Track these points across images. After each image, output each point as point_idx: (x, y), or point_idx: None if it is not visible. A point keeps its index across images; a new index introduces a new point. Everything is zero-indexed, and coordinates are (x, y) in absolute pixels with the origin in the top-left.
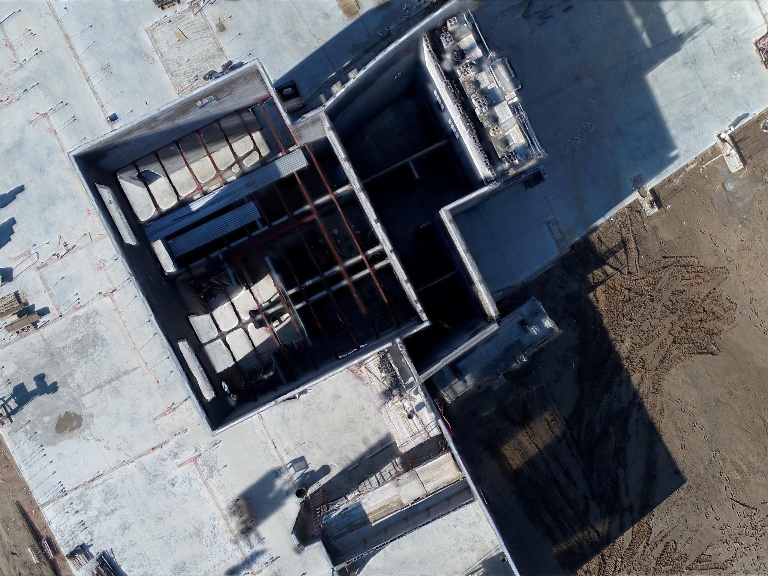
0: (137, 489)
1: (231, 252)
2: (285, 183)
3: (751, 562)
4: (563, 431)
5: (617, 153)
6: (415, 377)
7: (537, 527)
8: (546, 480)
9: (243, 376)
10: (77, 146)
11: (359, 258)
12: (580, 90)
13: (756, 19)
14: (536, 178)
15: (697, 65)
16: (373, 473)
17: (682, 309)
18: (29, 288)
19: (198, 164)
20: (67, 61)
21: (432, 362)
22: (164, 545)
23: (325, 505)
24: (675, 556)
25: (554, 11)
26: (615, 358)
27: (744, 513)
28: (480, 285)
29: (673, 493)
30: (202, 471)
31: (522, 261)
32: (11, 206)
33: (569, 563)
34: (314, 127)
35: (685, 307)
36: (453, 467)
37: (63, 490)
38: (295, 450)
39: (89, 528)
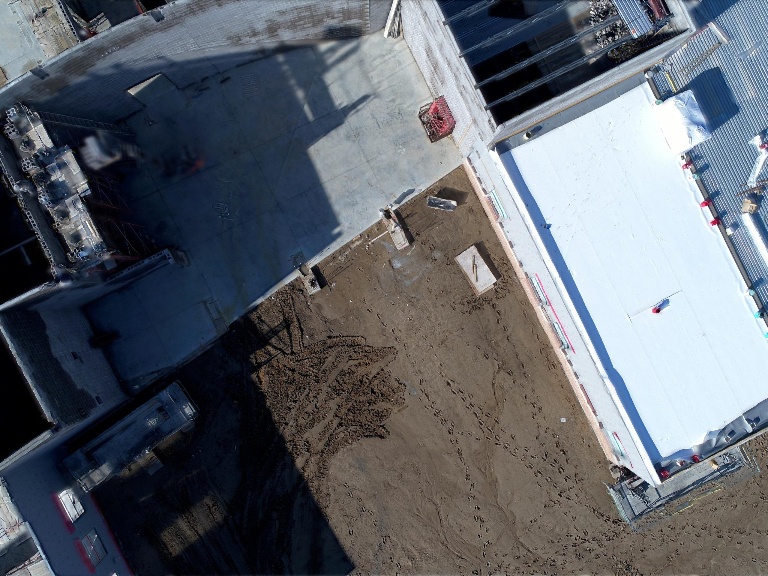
0: None
1: None
2: None
3: None
4: (225, 516)
5: (277, 230)
6: None
7: None
8: (207, 567)
9: None
10: None
11: None
12: (239, 164)
13: (422, 91)
14: None
15: (360, 139)
16: (22, 561)
17: (349, 390)
18: None
19: None
20: None
21: None
22: None
23: None
24: None
25: (211, 82)
26: (279, 441)
27: None
28: (33, 390)
29: None
30: None
31: (178, 341)
32: None
33: None
34: None
35: (353, 388)
36: None
37: None
38: None
39: None
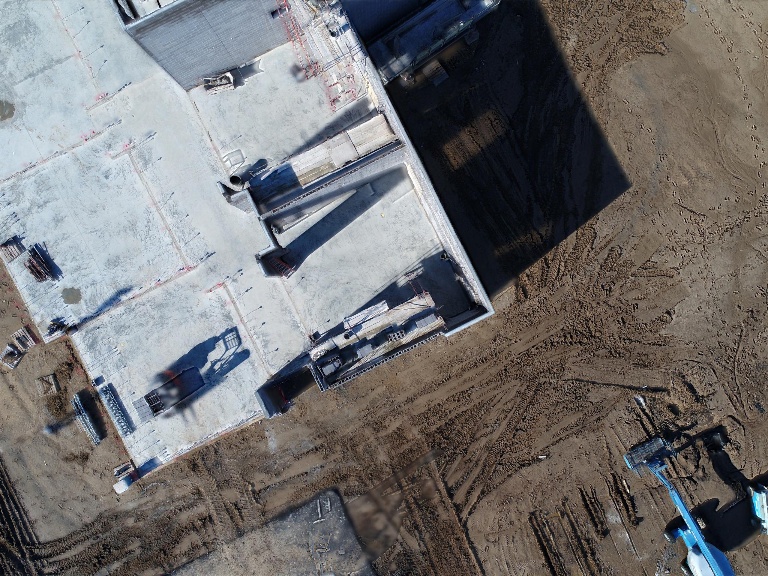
0: (70, 181)
1: None
2: None
3: (698, 270)
4: (506, 130)
5: None
6: None
7: (479, 229)
8: (488, 181)
9: None
10: None
11: None
12: None
13: None
14: None
15: None
16: None
17: (630, 6)
18: None
19: None
20: None
21: None
22: (97, 239)
23: None
24: (620, 262)
25: None
26: (561, 56)
27: (692, 219)
28: None
29: (619, 197)
30: (136, 163)
31: None
32: None
33: (511, 267)
34: None
35: (633, 5)
36: (386, 129)
37: None
38: (231, 143)
39: (21, 220)
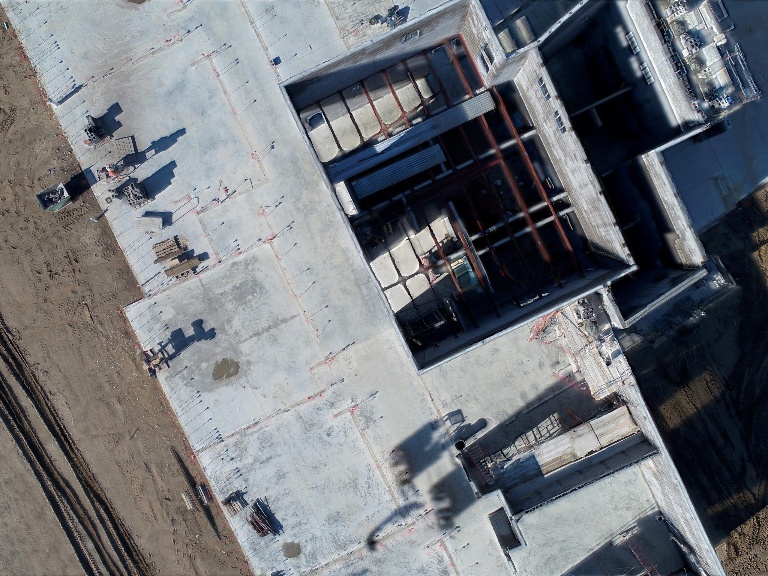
0: (292, 438)
1: (415, 195)
2: (471, 126)
3: None
4: (722, 391)
5: None
6: (617, 323)
7: (692, 487)
8: (703, 440)
9: (405, 326)
10: (240, 90)
11: (544, 205)
12: (753, 42)
13: None
14: (714, 130)
15: None
16: (530, 428)
17: None
18: (189, 233)
19: (361, 111)
20: (231, 2)
21: (638, 307)
22: (318, 494)
23: (488, 457)
24: None
25: None
26: None
27: None
28: (689, 230)
29: None
30: (358, 421)
31: None
32: (172, 149)
33: (723, 524)
34: (515, 66)
35: None
36: (628, 420)
37: (219, 437)
38: (452, 403)
39: (244, 475)
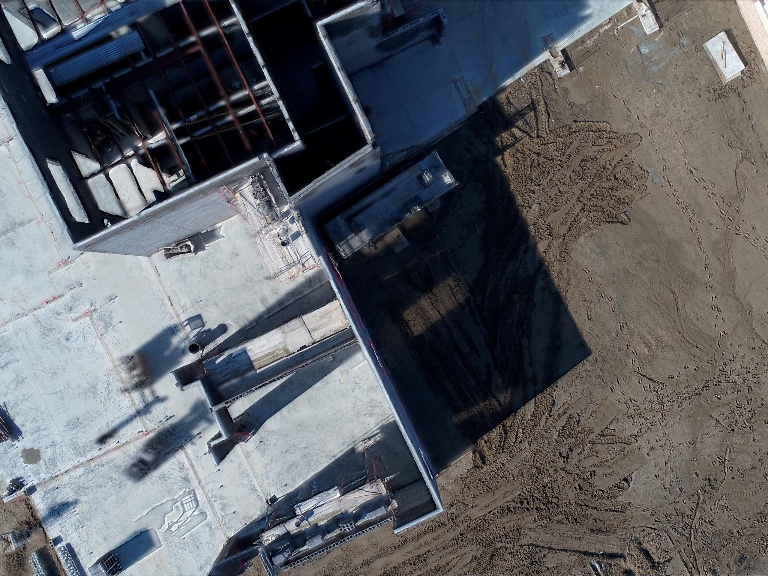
0: (31, 343)
1: (114, 83)
2: (171, 14)
3: (656, 438)
4: (466, 297)
5: (529, 11)
6: None
7: (437, 395)
8: (448, 347)
9: None
10: None
11: (246, 94)
12: None
13: None
14: (439, 28)
15: None
16: None
17: (592, 176)
18: None
19: None
20: None
21: None
22: (57, 400)
23: None
24: (578, 429)
25: None
26: (522, 224)
27: (650, 387)
28: (355, 105)
29: (578, 365)
30: (97, 326)
31: (428, 120)
32: None
33: (469, 432)
34: None
35: (596, 174)
36: (341, 315)
37: None
38: (192, 308)
39: None
